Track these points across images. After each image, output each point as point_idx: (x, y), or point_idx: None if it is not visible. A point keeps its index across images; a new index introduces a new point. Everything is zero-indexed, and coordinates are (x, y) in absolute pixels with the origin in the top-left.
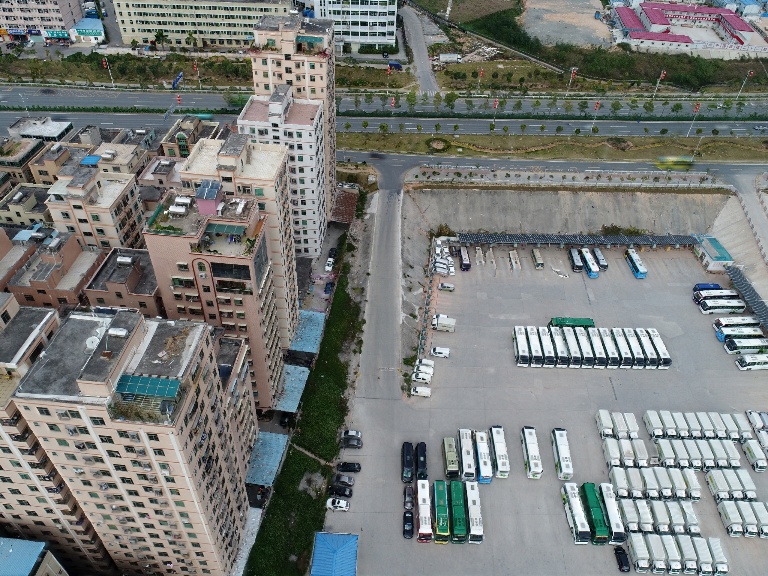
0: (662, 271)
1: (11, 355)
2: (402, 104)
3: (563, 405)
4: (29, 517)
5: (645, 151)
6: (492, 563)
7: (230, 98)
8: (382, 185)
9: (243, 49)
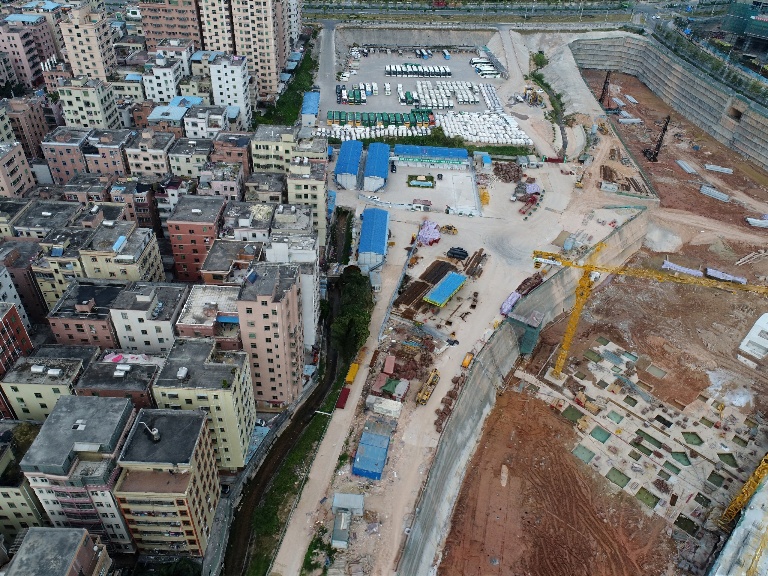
0: (459, 58)
1: None
2: (334, 5)
3: None
4: None
5: (459, 19)
6: None
7: None
8: (325, 27)
9: None
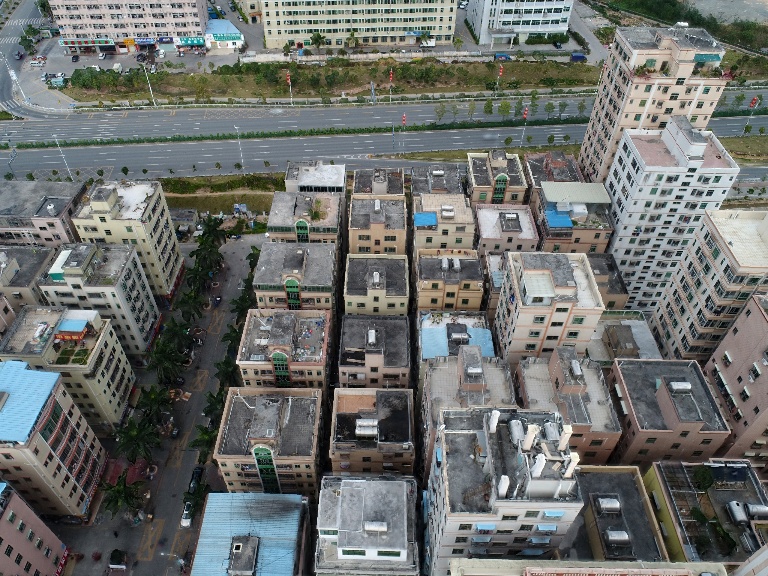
0: None
1: None
2: None
3: None
4: None
5: None
6: None
7: (443, 111)
8: None
9: (399, 46)
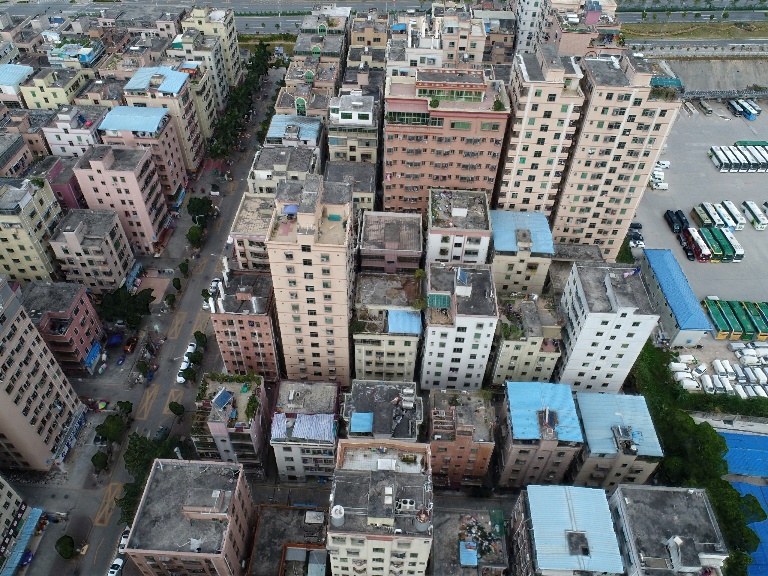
0: None
1: (573, 73)
2: None
3: (762, 192)
4: (521, 205)
5: (767, 31)
6: (752, 271)
7: None
8: None
9: None
